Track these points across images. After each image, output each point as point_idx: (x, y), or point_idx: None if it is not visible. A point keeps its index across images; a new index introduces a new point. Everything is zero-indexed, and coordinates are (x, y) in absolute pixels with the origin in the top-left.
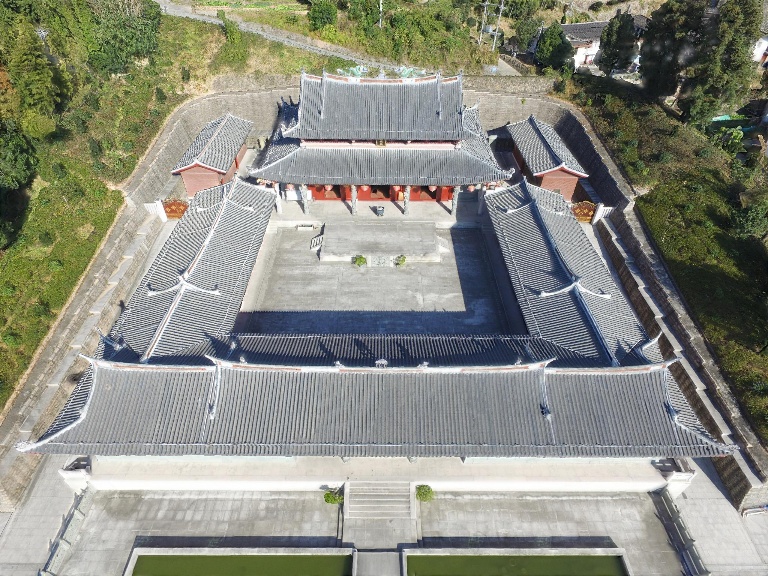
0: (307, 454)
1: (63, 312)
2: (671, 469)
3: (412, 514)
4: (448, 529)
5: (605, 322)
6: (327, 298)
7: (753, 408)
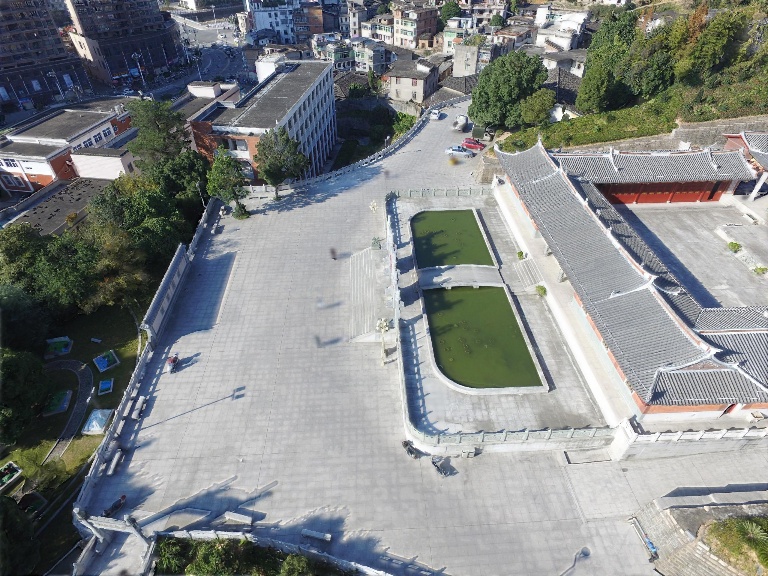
0: (531, 214)
1: (573, 148)
2: (635, 430)
3: (527, 287)
4: (526, 306)
5: (761, 349)
6: (674, 238)
7: (765, 519)
